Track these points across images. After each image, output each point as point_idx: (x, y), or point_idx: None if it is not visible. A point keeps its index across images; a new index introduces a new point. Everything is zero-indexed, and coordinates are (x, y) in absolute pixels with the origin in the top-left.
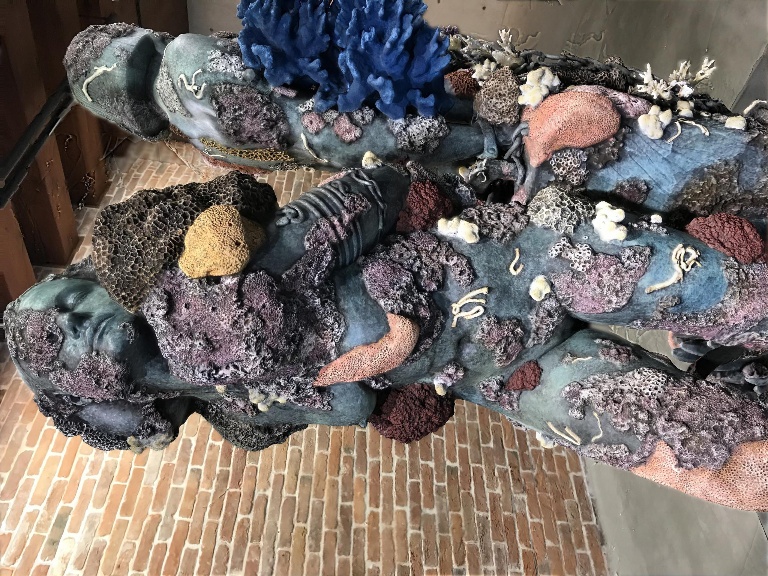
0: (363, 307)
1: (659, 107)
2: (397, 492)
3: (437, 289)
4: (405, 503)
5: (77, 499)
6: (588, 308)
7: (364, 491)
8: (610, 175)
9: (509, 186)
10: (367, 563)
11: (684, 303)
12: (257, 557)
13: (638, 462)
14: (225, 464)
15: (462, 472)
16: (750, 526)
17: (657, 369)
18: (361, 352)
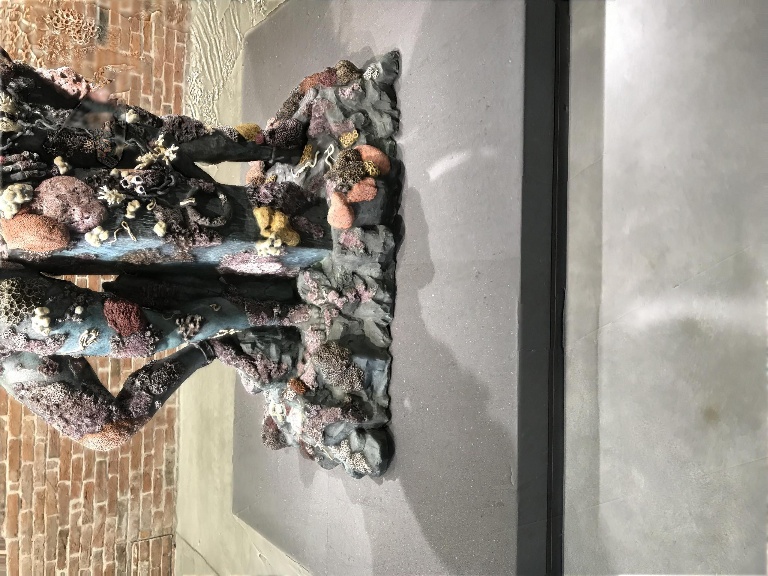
0: None
1: (100, 230)
2: None
3: None
4: None
5: None
6: None
7: None
8: None
9: None
10: None
11: None
12: None
13: None
14: None
15: None
16: None
17: (65, 384)
18: None
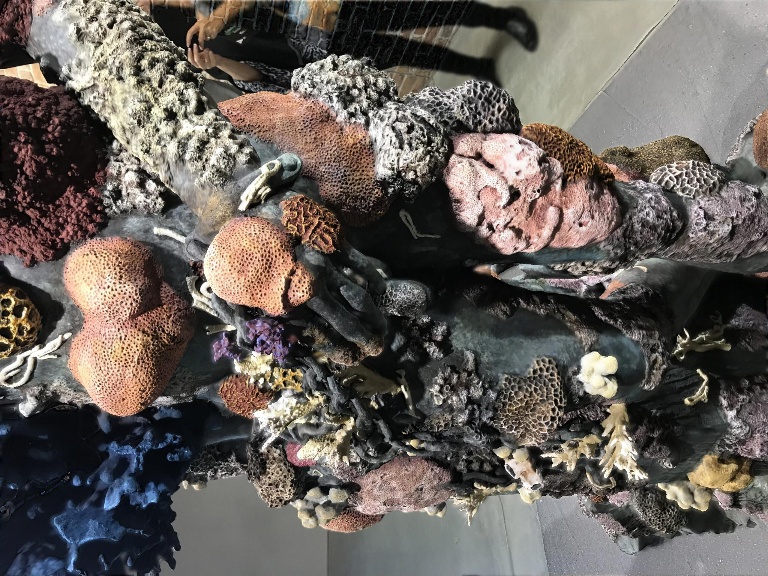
0: None
1: None
2: None
3: None
4: None
5: None
6: None
7: None
8: None
9: None
10: None
11: None
12: None
13: None
14: None
15: None
16: None
17: None
18: None
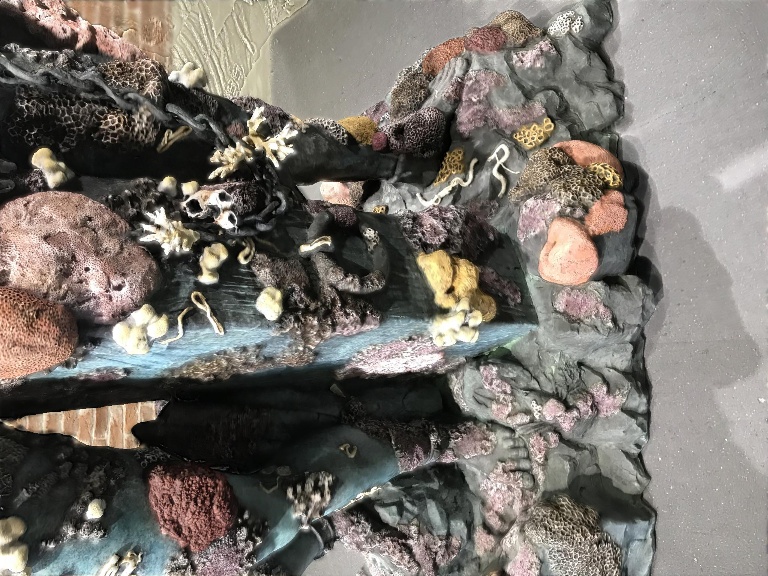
0: None
1: (151, 314)
2: None
3: None
4: None
5: None
6: None
7: None
8: None
9: None
10: None
11: None
12: None
13: None
14: None
15: None
16: None
17: None
18: None
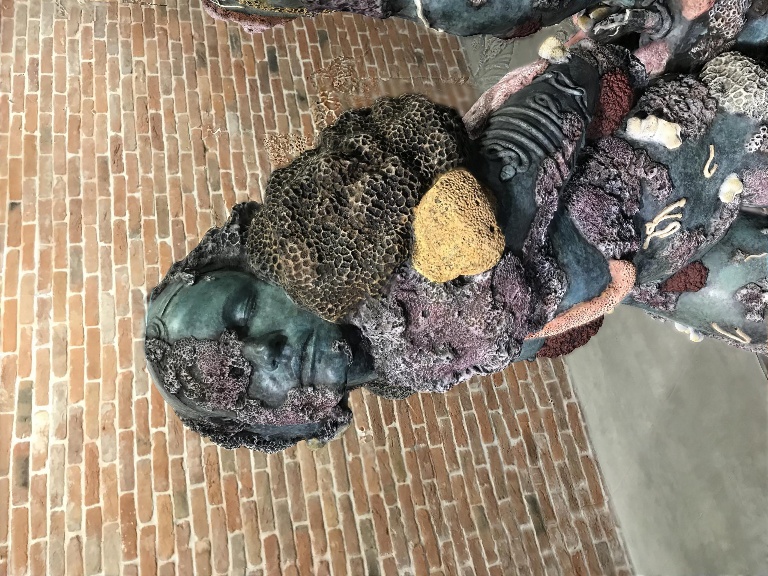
0: (584, 257)
1: None
2: None
3: (639, 211)
4: None
5: (34, 371)
6: None
7: None
8: (767, 22)
9: (632, 36)
10: None
11: None
12: None
13: None
14: None
15: None
16: None
17: None
18: (583, 310)
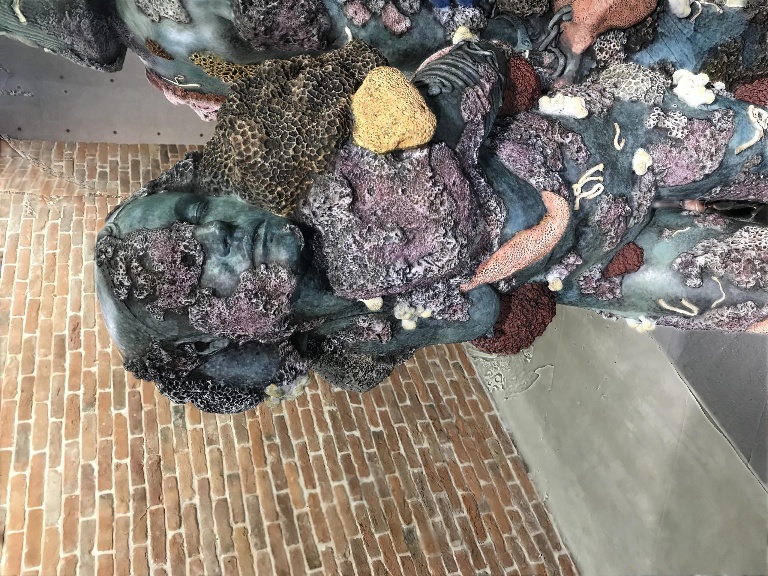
0: (517, 187)
1: None
2: (330, 468)
3: (562, 168)
4: (341, 477)
5: None
6: (680, 179)
7: (297, 475)
8: (644, 58)
9: None
10: (319, 546)
11: (764, 161)
12: (200, 571)
13: (765, 315)
14: (138, 482)
15: (388, 434)
16: (677, 414)
17: None
18: (525, 237)
